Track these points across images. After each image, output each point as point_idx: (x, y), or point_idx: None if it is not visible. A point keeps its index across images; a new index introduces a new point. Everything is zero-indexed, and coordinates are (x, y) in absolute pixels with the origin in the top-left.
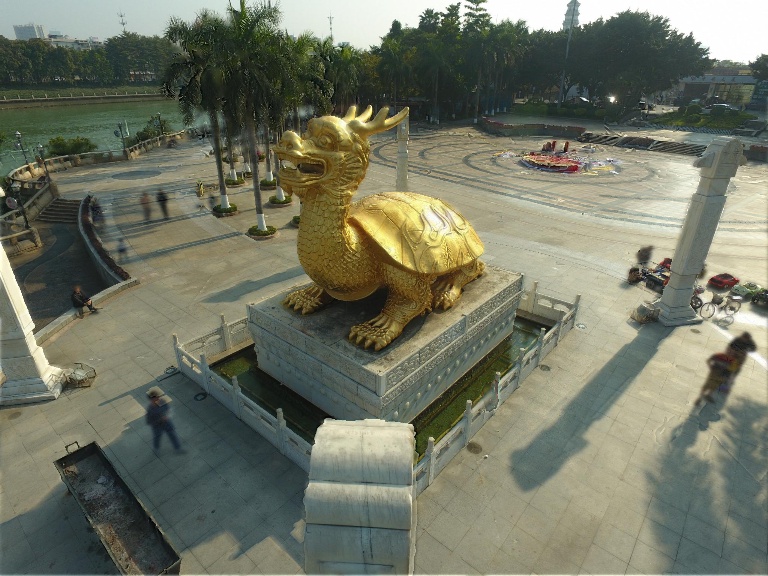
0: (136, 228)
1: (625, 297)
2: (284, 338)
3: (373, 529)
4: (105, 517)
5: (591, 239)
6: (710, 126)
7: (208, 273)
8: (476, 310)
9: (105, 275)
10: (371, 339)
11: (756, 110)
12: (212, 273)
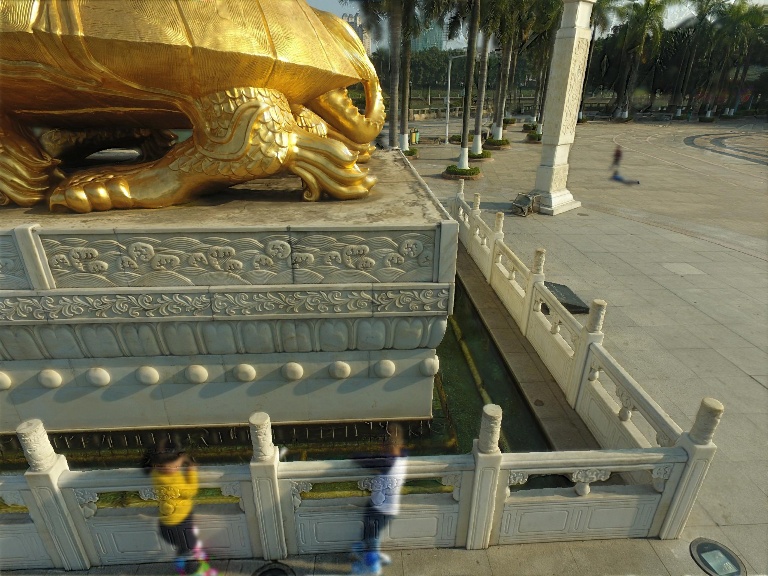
0: None
1: None
2: None
3: None
4: None
5: None
6: None
7: None
8: (95, 237)
9: None
10: None
11: None
12: None
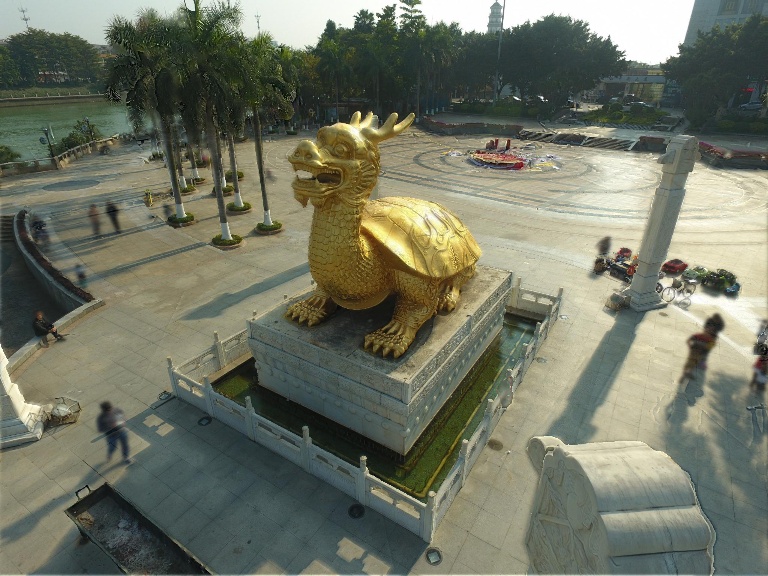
0: (86, 244)
1: (595, 287)
2: (293, 352)
3: (677, 553)
4: (138, 564)
5: (551, 233)
6: (632, 122)
7: (180, 288)
8: (478, 310)
9: (62, 297)
10: (389, 347)
11: (669, 107)
12: (184, 288)
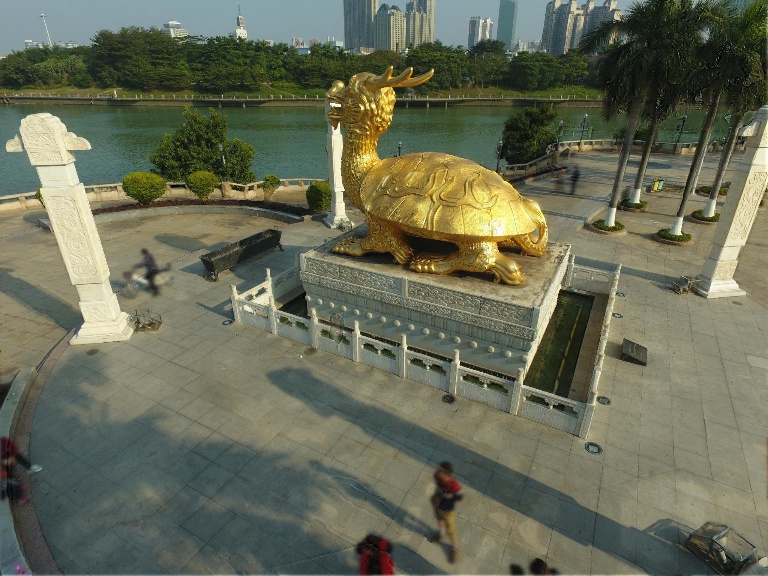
0: (539, 192)
1: None
2: None
3: None
4: None
5: None
6: None
7: None
8: (423, 285)
9: None
10: None
11: None
12: None
